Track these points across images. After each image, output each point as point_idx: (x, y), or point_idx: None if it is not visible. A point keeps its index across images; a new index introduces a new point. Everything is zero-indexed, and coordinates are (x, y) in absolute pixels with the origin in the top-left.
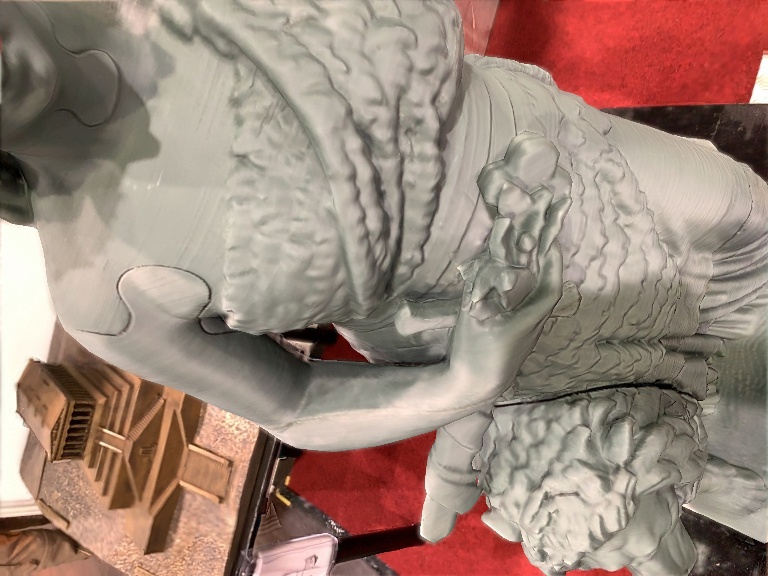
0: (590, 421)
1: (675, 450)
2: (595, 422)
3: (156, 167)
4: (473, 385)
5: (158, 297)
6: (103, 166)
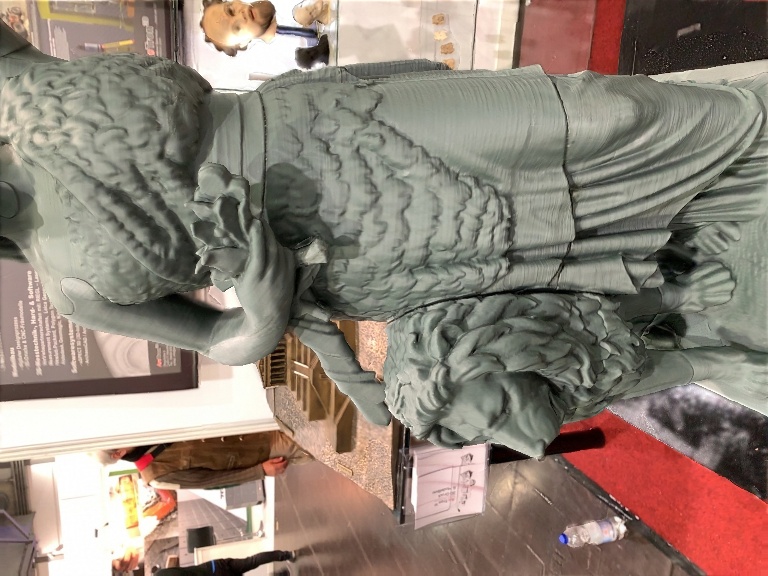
0: (421, 329)
1: (498, 345)
2: (426, 329)
3: (45, 230)
4: (253, 318)
5: (78, 292)
6: (32, 232)
